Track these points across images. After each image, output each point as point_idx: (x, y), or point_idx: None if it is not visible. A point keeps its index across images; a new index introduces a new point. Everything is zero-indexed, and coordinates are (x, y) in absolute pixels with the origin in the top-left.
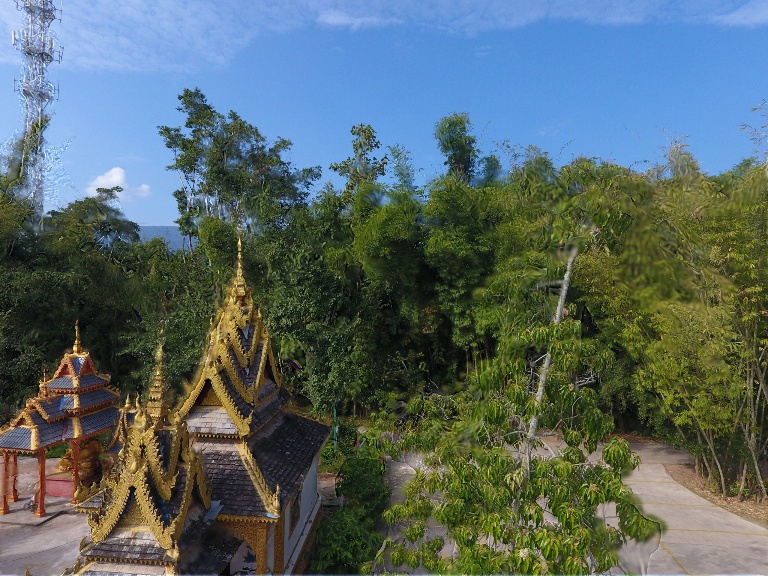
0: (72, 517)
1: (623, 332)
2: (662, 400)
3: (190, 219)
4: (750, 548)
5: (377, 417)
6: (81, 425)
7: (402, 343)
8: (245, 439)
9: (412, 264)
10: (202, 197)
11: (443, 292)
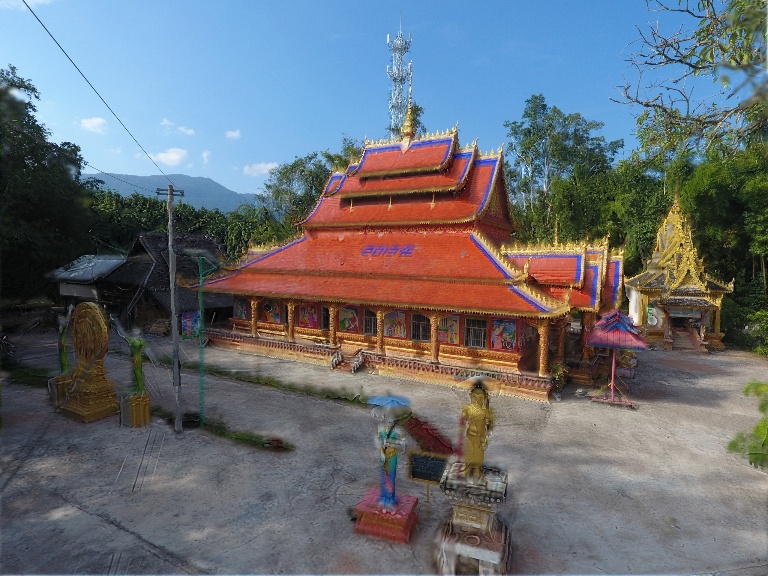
0: None
1: None
2: None
3: (526, 182)
4: None
5: None
6: None
7: None
8: None
9: (725, 200)
10: (519, 167)
11: (749, 217)
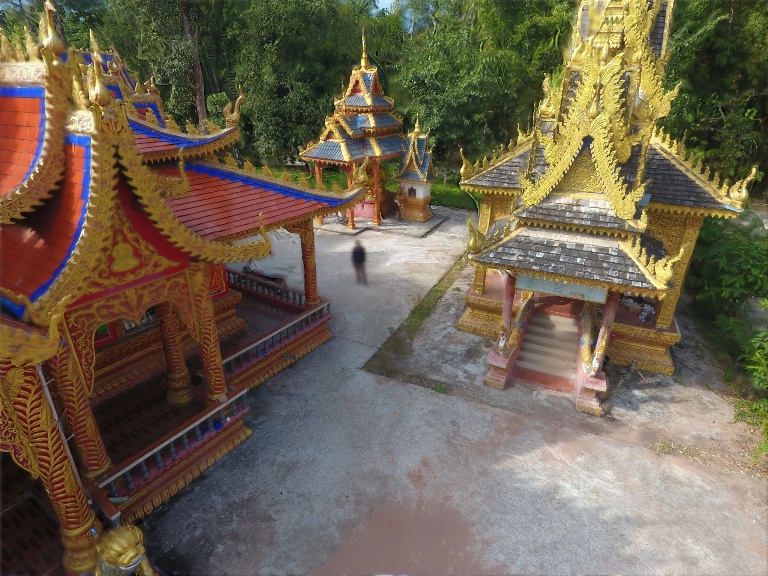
0: (378, 233)
1: None
2: None
3: None
4: None
5: None
6: (379, 145)
7: (728, 80)
8: (660, 123)
9: None
10: None
11: None
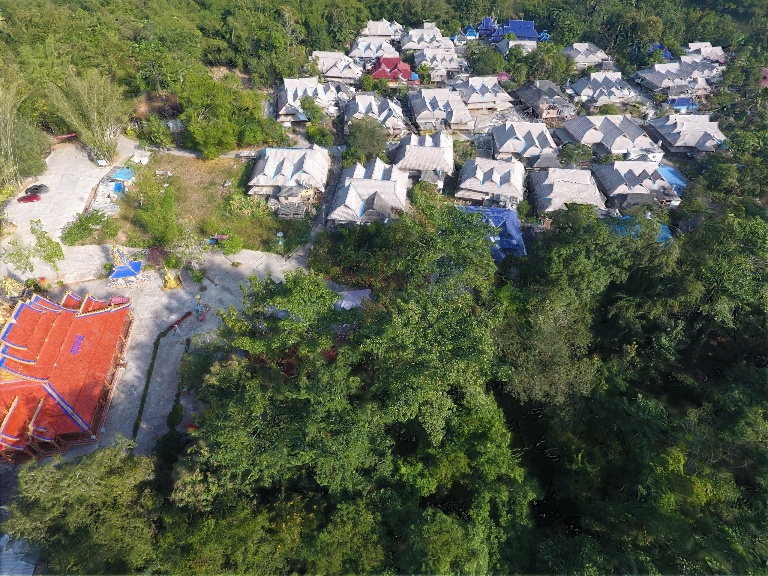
0: None
1: None
2: None
3: None
4: (7, 246)
5: None
6: None
7: None
8: None
9: None
10: None
11: None
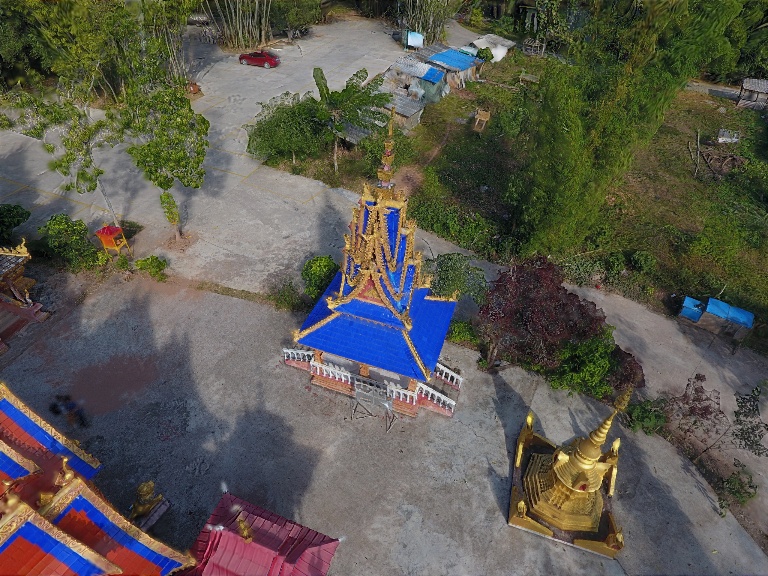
0: None
1: (27, 2)
2: (68, 51)
3: None
4: None
5: (0, 121)
6: None
7: None
8: None
9: None
10: None
11: None
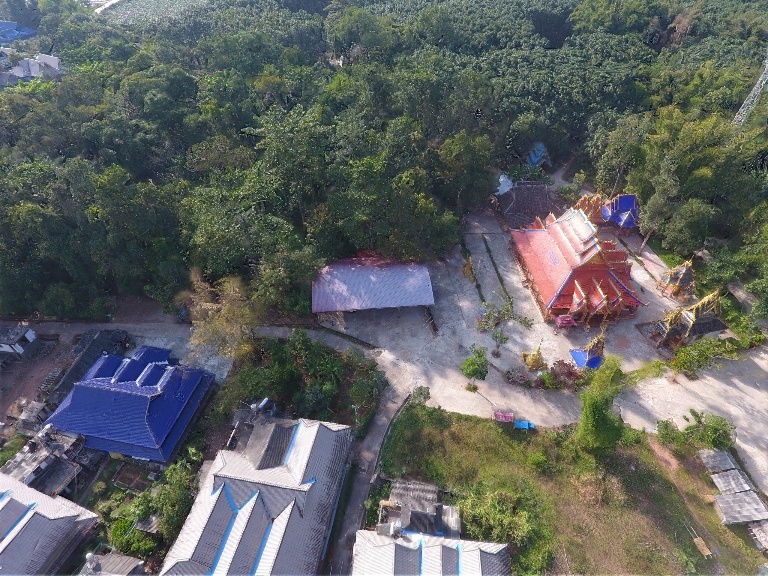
0: (667, 299)
1: None
2: None
3: None
4: None
5: (711, 337)
6: (680, 282)
7: None
8: (693, 322)
9: None
10: None
11: None
